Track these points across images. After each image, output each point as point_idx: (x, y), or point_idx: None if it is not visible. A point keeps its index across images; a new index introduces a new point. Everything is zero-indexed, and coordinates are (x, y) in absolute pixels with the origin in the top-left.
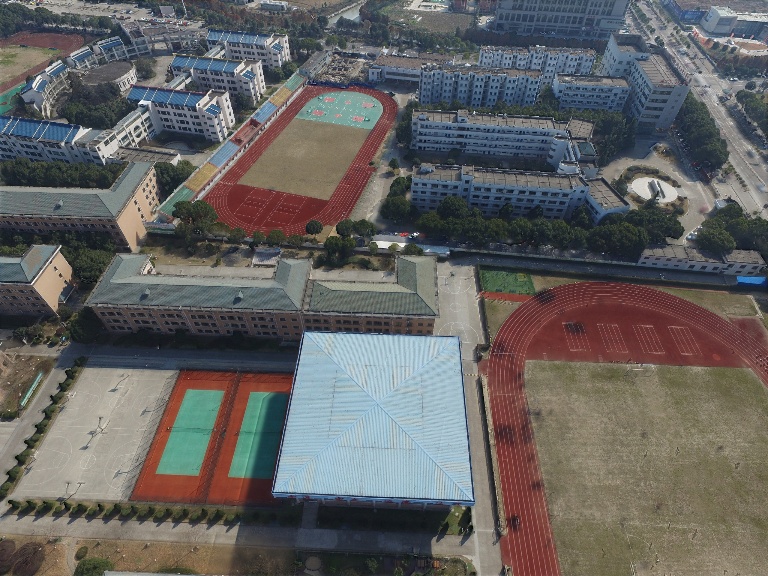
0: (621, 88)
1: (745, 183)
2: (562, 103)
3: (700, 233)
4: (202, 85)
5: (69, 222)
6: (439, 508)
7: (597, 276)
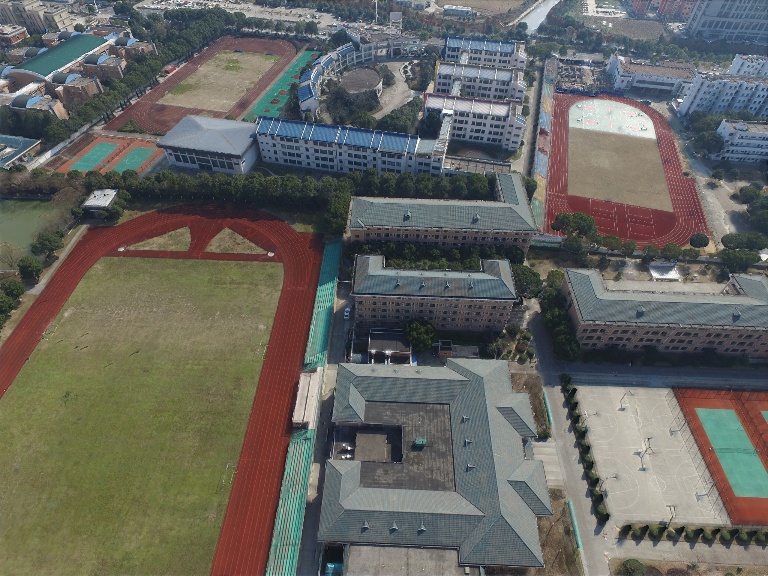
0: None
1: None
2: None
3: None
4: None
5: (482, 235)
6: None
7: None
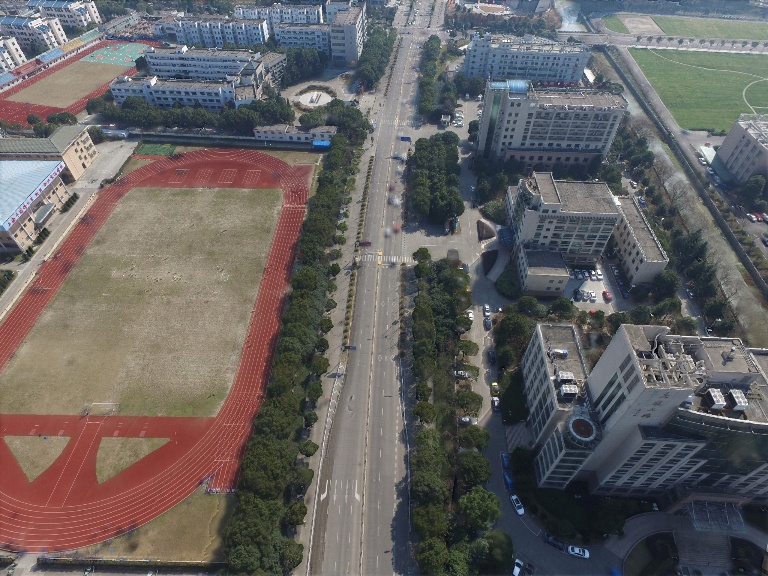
0: (320, 31)
1: (387, 94)
2: (283, 45)
3: (300, 116)
4: None
5: None
6: (15, 251)
7: (222, 145)
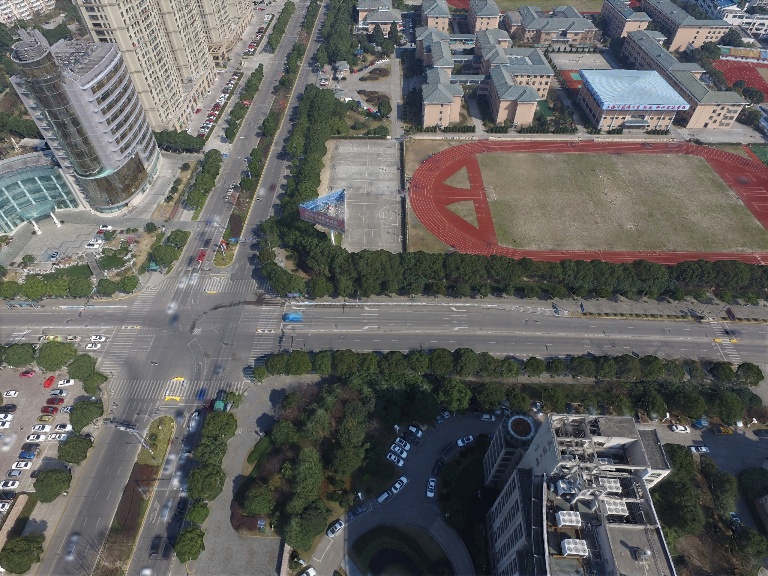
0: None
1: None
2: None
3: None
4: None
5: None
6: None
7: None
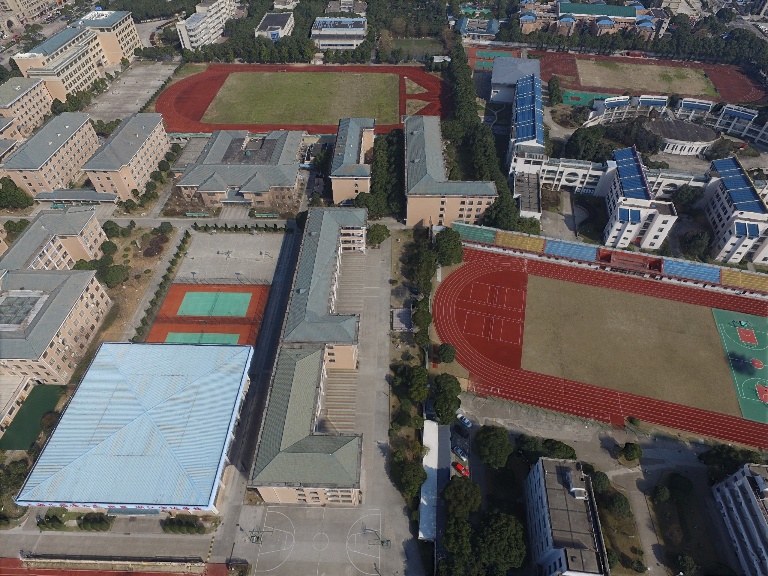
0: None
1: None
2: None
3: None
4: (712, 200)
5: None
6: None
7: None
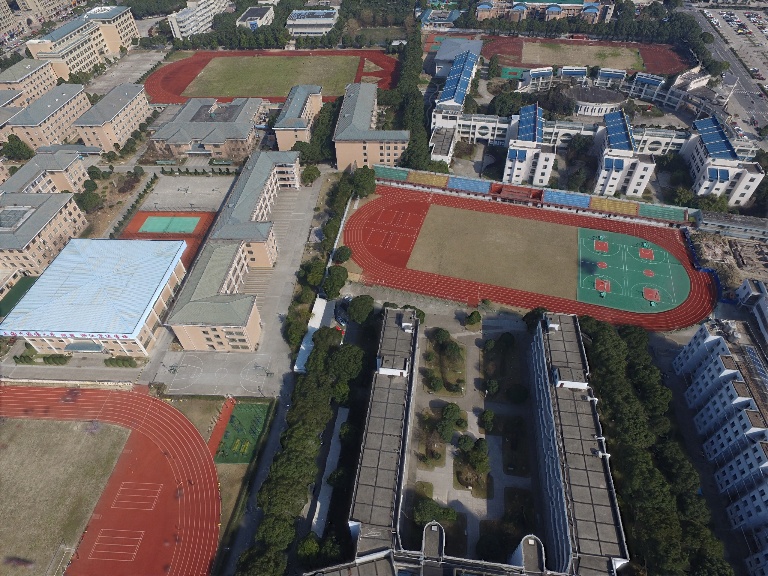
0: None
1: None
2: None
3: None
4: (601, 147)
5: None
6: None
7: (219, 560)
